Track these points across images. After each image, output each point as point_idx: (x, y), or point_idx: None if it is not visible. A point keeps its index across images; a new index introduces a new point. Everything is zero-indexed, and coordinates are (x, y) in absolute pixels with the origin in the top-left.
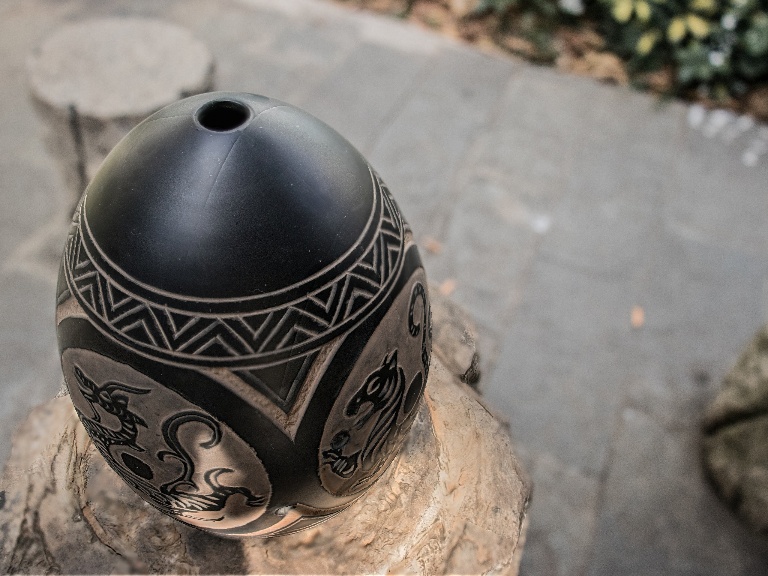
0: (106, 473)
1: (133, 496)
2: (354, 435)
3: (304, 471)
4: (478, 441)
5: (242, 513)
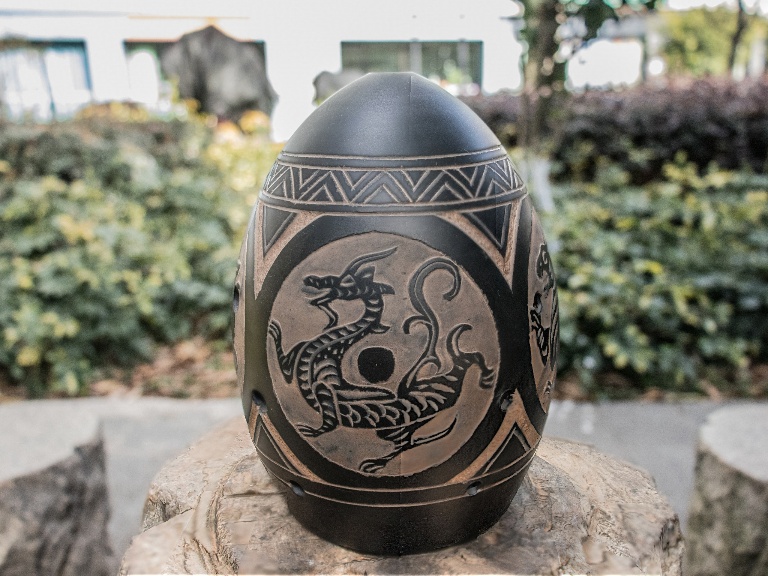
0: (253, 552)
1: (294, 560)
2: (544, 304)
3: (521, 333)
4: (580, 458)
5: (472, 408)
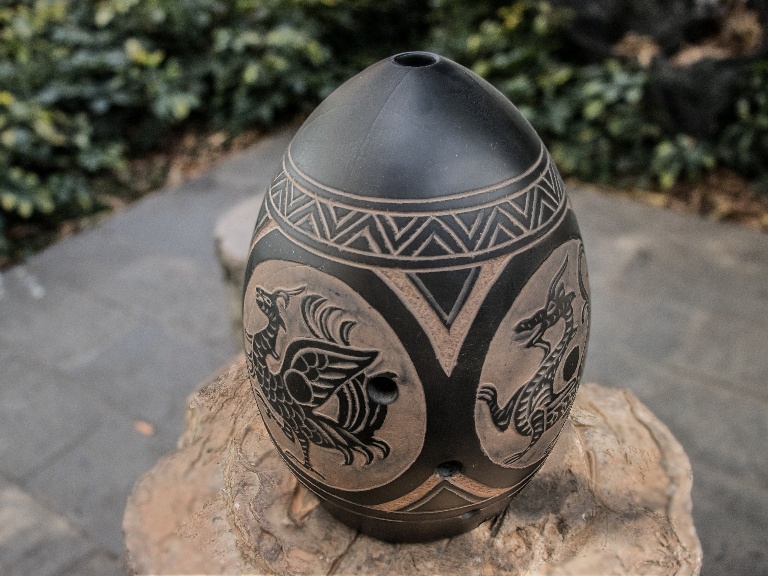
0: None
1: (471, 570)
2: None
3: None
4: None
5: None
